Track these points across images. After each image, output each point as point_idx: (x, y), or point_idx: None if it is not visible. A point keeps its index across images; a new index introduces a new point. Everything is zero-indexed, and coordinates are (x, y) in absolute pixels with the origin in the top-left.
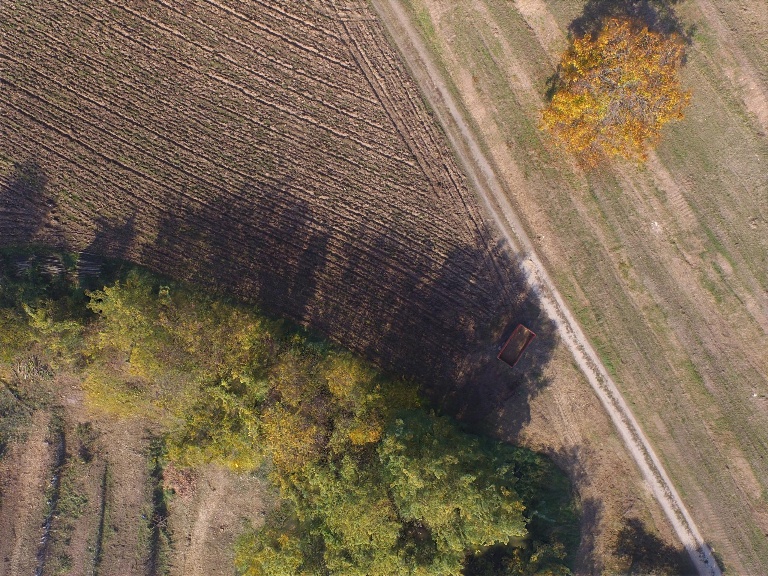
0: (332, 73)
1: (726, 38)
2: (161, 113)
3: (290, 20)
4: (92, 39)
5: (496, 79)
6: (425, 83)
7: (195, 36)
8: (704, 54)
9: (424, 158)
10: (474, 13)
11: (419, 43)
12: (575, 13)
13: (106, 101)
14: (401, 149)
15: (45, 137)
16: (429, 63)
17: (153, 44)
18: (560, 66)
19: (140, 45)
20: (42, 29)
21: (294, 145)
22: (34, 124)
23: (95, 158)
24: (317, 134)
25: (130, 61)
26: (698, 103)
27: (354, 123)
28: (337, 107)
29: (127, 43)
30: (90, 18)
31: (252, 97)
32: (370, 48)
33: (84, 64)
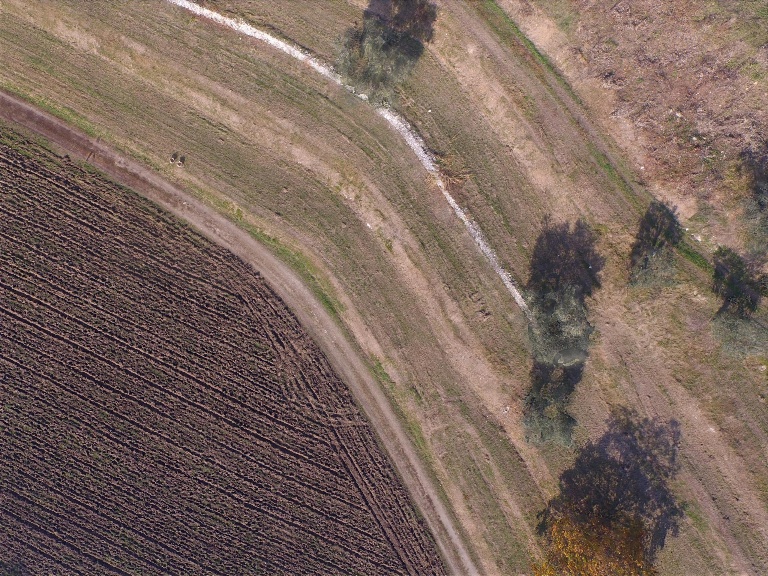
0: (322, 479)
1: (718, 525)
2: (148, 515)
3: (280, 426)
4: (80, 442)
5: (487, 499)
6: (415, 489)
7: (184, 441)
8: (696, 529)
9: (413, 566)
10: (465, 434)
11: (410, 450)
12: (567, 464)
13: (93, 503)
14: (390, 557)
15: (31, 537)
16: (420, 470)
17: (142, 447)
18: (551, 503)
19: (128, 448)
20: (30, 431)
21: (282, 549)
22: (20, 525)
23: (81, 558)
24: (306, 540)
25: (118, 464)
26: (689, 574)
27: (343, 530)
28: (326, 513)
29: (115, 446)
30: (78, 422)
31: (241, 501)
32: (360, 454)
33: (71, 466)
